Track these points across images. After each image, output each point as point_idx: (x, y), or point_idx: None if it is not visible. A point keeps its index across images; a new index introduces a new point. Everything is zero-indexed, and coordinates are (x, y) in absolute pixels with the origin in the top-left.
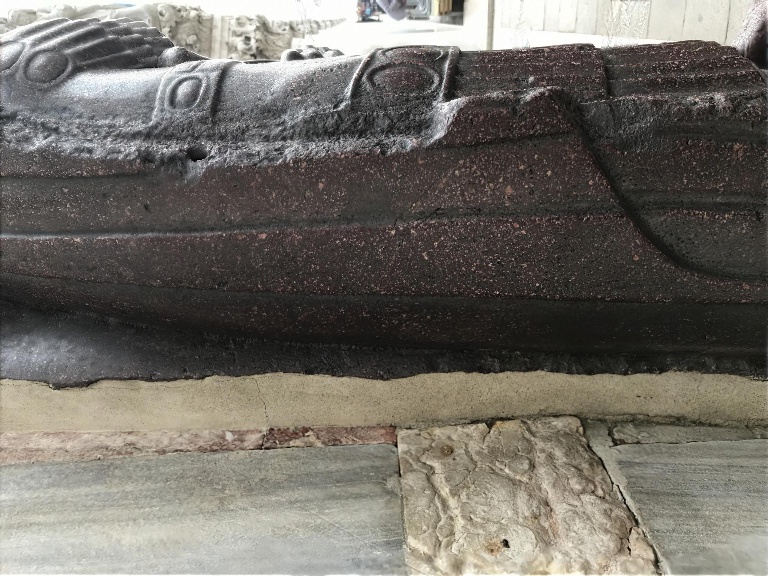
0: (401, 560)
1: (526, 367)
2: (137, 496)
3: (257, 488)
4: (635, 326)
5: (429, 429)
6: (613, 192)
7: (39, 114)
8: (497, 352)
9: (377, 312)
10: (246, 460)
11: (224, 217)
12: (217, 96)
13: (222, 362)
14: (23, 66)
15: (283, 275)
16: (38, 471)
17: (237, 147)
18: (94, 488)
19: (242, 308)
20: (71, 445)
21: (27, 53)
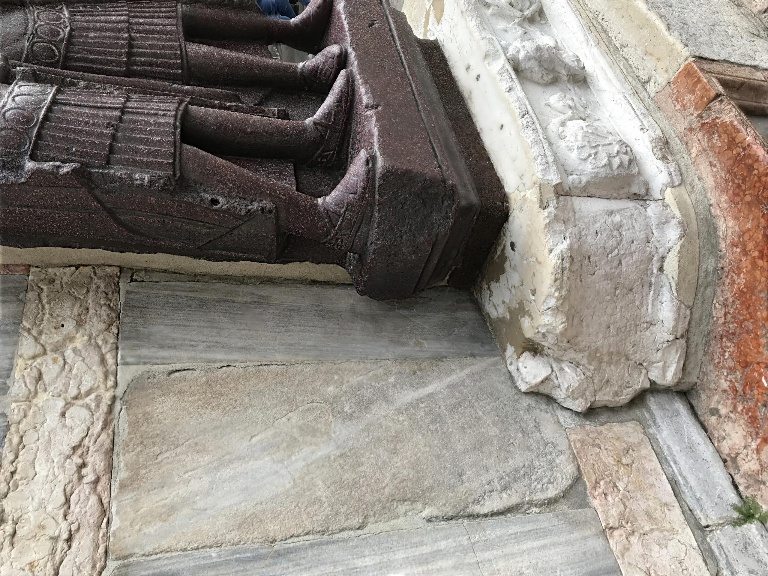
0: (18, 330)
1: (92, 247)
2: None
3: None
4: None
5: (46, 268)
6: (103, 208)
7: None
8: None
9: (8, 231)
10: None
11: None
12: None
13: None
14: None
15: None
16: None
17: None
18: None
19: None
20: None
21: None
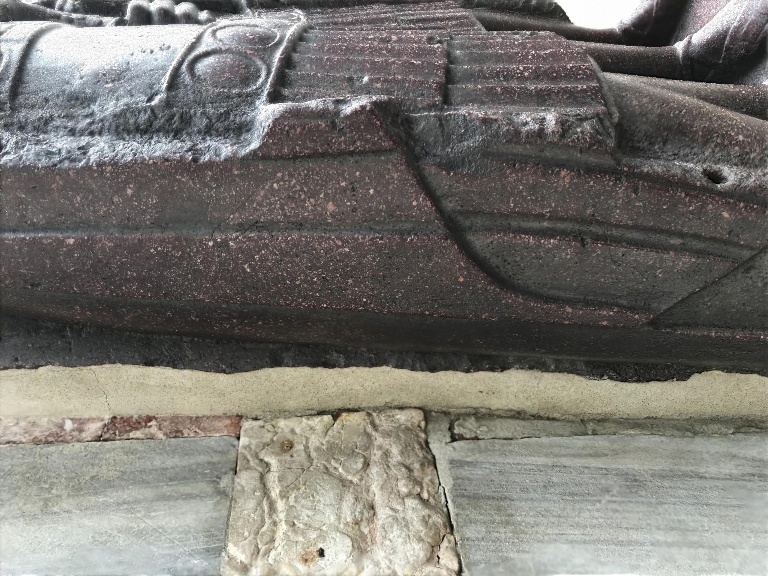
0: (216, 570)
1: (371, 363)
2: None
3: (86, 487)
4: (467, 338)
5: (274, 421)
6: (438, 213)
7: None
8: (343, 347)
9: (206, 317)
10: (80, 454)
11: (26, 219)
12: (19, 76)
13: (57, 351)
14: None
15: (99, 280)
16: None
17: (37, 141)
18: None
19: (63, 307)
20: None
21: None
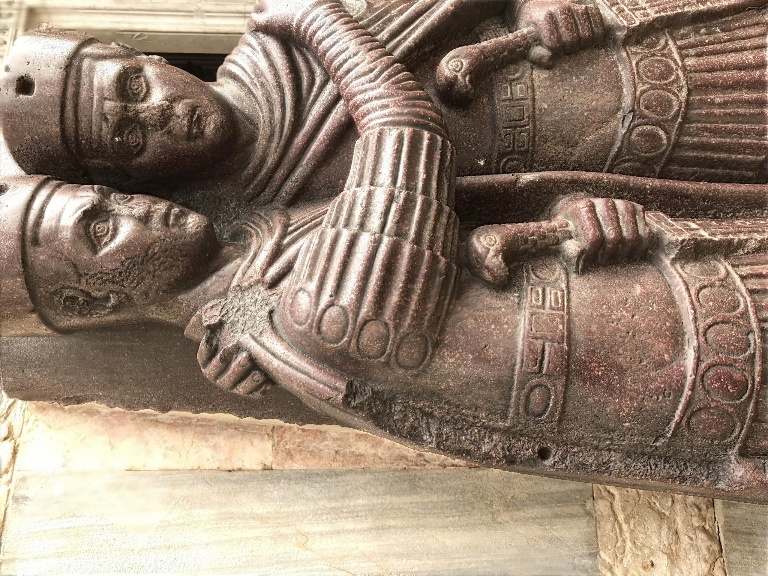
0: (597, 567)
1: None
2: (442, 507)
3: (511, 505)
4: None
5: None
6: None
7: (414, 398)
8: None
9: None
10: (499, 478)
11: None
12: (562, 408)
13: None
14: (395, 355)
15: None
16: (371, 478)
17: (574, 452)
18: (413, 497)
19: None
20: (381, 452)
21: (395, 341)
